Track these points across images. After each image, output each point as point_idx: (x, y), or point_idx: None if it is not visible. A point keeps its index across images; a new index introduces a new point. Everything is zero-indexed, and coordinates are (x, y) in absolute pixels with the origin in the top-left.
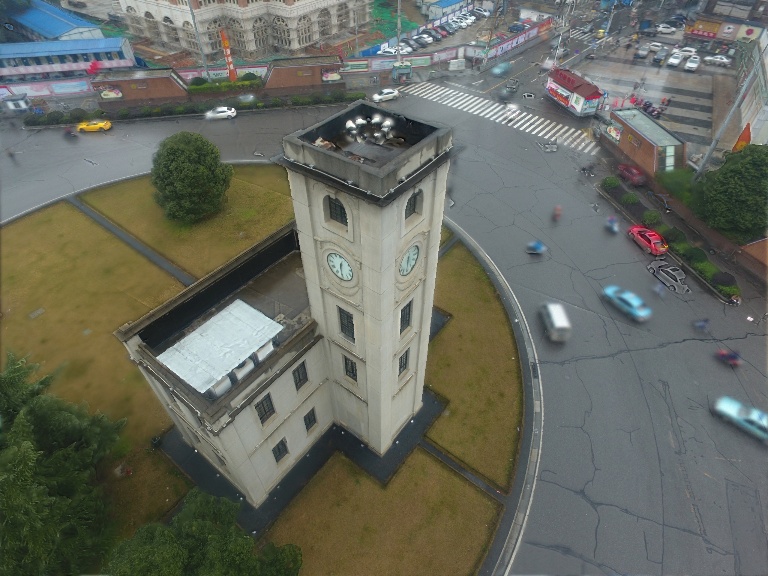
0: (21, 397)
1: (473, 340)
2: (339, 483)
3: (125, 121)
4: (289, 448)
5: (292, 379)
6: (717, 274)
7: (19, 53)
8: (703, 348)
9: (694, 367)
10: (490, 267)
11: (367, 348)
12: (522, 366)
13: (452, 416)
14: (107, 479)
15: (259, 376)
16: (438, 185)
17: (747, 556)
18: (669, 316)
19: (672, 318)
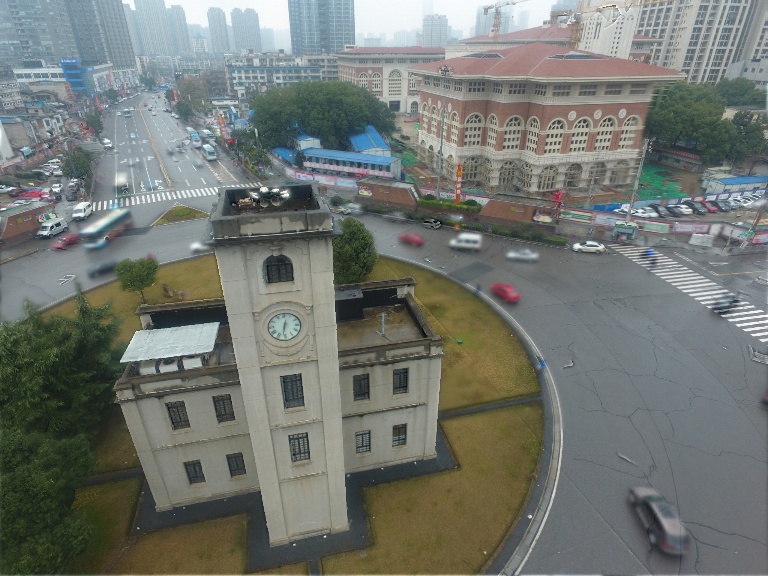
0: (91, 328)
1: (458, 503)
2: (220, 540)
3: (362, 212)
4: (205, 477)
5: (213, 405)
6: None
7: (330, 156)
8: None
9: None
10: (552, 445)
11: None
12: (488, 568)
13: (363, 561)
14: (118, 425)
15: (174, 379)
16: (316, 262)
17: None
18: None
19: None
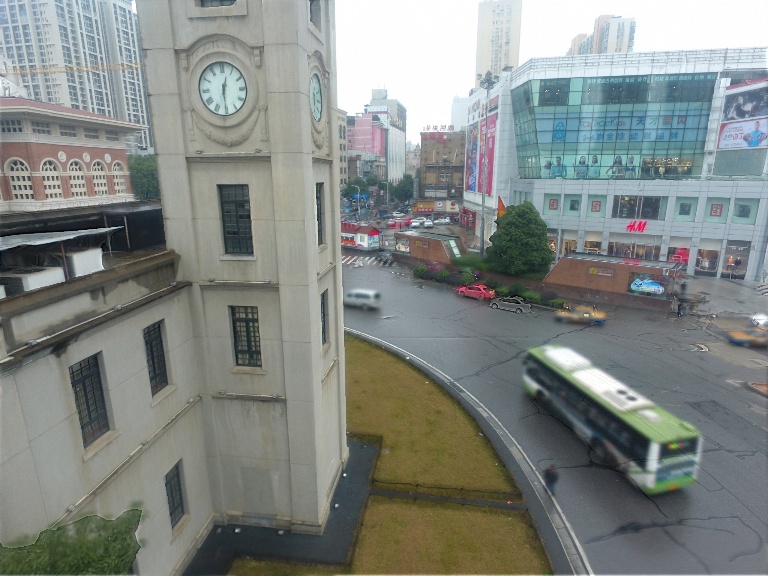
0: None
1: (373, 381)
2: None
3: None
4: (139, 559)
5: (143, 353)
6: (542, 293)
7: None
8: (575, 336)
9: (582, 347)
10: (353, 332)
11: (280, 239)
12: None
13: (395, 450)
14: None
15: (80, 293)
16: (330, 9)
17: (767, 446)
18: (532, 326)
19: (536, 327)
